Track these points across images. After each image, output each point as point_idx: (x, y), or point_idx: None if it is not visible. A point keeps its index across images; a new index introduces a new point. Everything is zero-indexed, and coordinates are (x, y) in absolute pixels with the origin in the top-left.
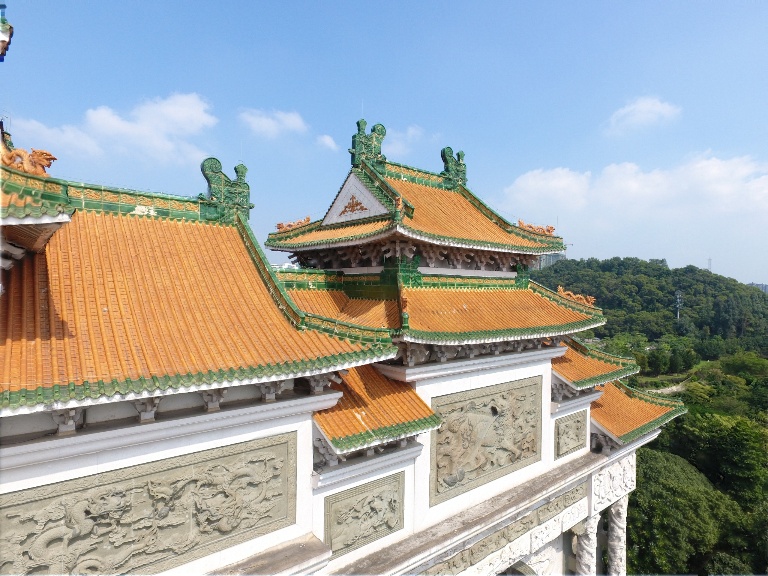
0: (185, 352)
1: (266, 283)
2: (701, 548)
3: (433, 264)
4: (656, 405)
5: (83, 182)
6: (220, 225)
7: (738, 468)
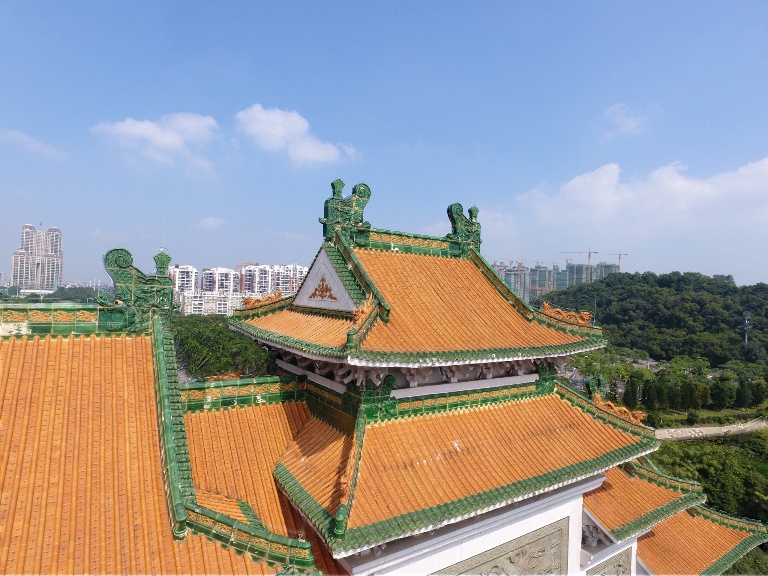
0: None
1: (160, 438)
2: None
3: (415, 382)
4: (727, 527)
5: None
6: (128, 336)
7: None
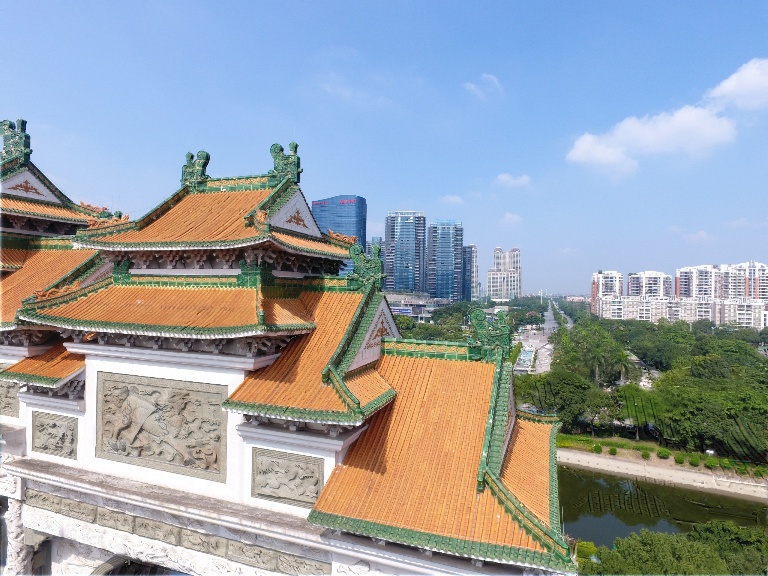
0: None
1: None
2: None
3: (145, 266)
4: (519, 527)
5: None
6: None
7: None
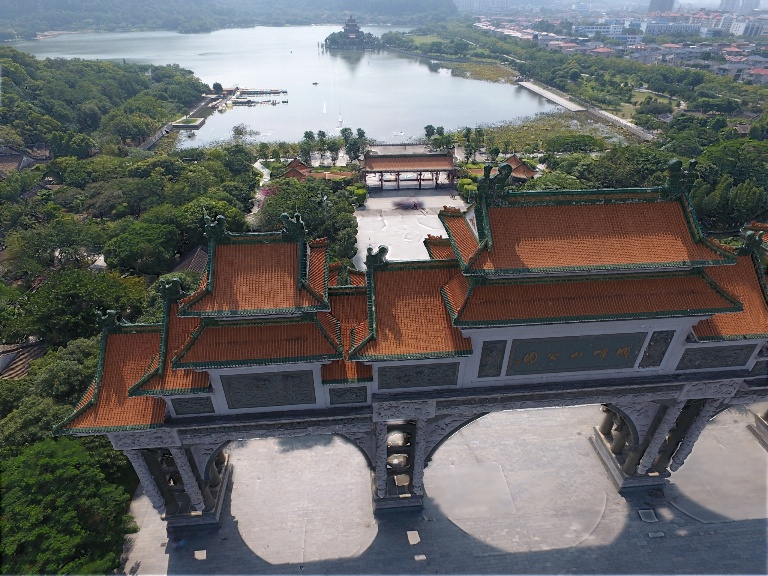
0: None
1: None
2: None
3: None
4: None
5: (428, 260)
6: None
7: None
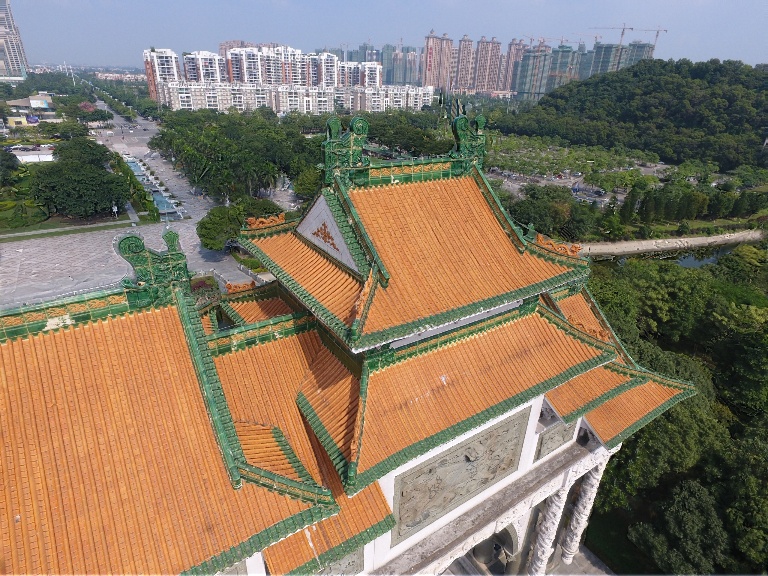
0: (103, 569)
1: (206, 407)
2: (677, 468)
3: None
4: (664, 386)
5: None
6: (156, 308)
7: (752, 370)
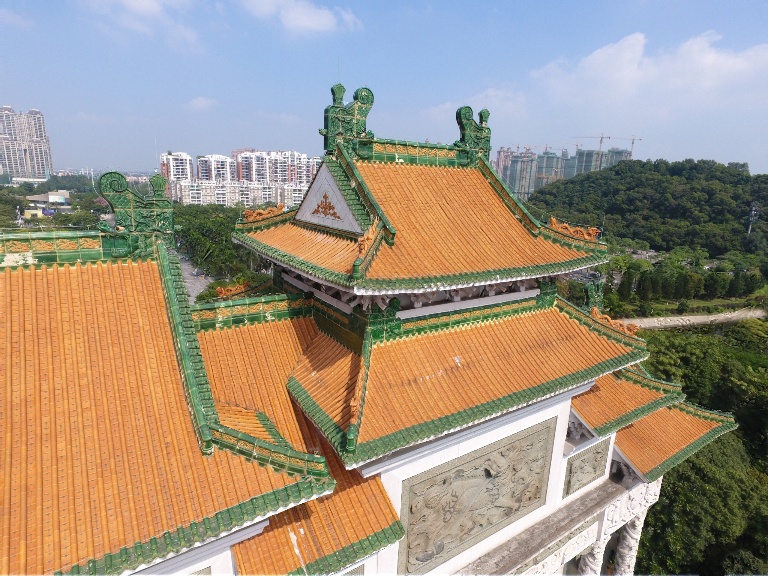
0: (15, 538)
1: (178, 363)
2: (723, 538)
3: (420, 303)
4: (699, 418)
5: None
6: (134, 261)
7: None
